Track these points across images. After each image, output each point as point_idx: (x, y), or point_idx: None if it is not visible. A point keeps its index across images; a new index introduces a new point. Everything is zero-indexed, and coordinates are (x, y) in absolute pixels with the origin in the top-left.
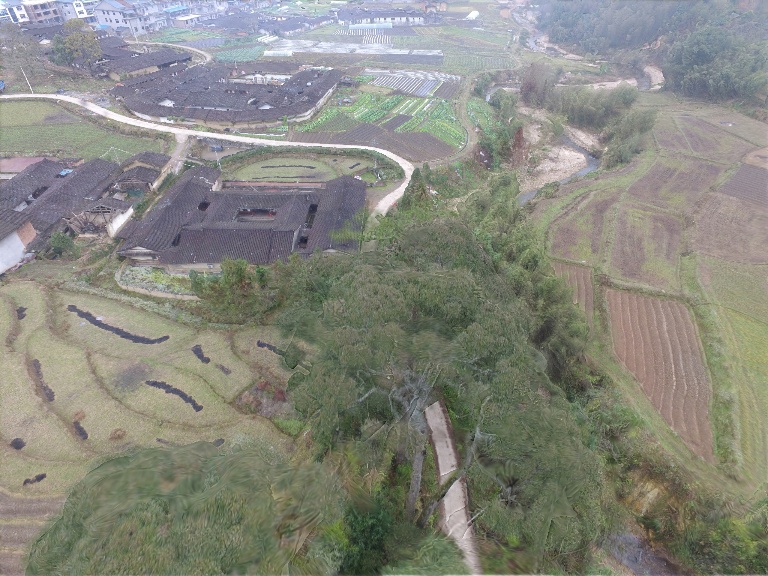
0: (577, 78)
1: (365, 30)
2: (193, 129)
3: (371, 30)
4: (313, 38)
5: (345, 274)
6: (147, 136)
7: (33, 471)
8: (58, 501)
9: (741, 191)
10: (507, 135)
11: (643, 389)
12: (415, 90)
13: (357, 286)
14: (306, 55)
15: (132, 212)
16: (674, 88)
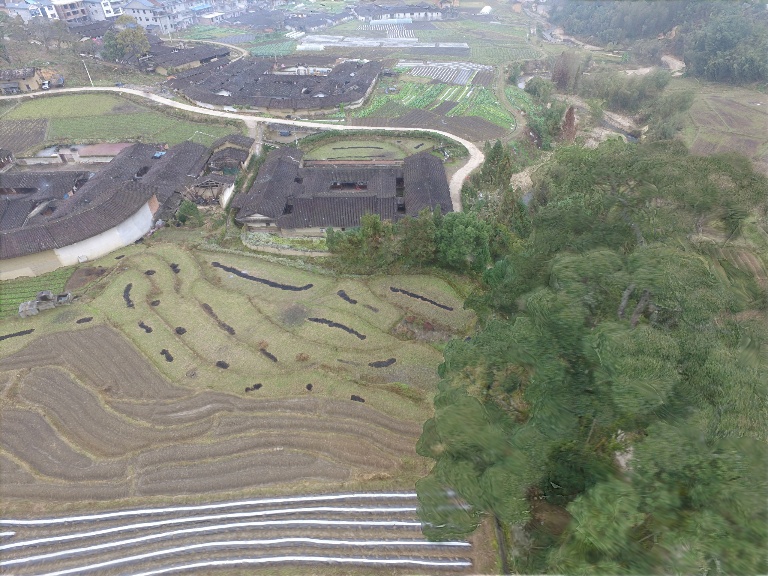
0: (601, 67)
1: (386, 25)
2: (259, 116)
3: (392, 25)
4: (338, 33)
5: (636, 163)
6: (217, 123)
7: (249, 382)
8: (284, 401)
9: None
10: (558, 116)
11: None
12: (453, 79)
13: (660, 165)
14: (337, 49)
15: (234, 187)
16: (696, 74)
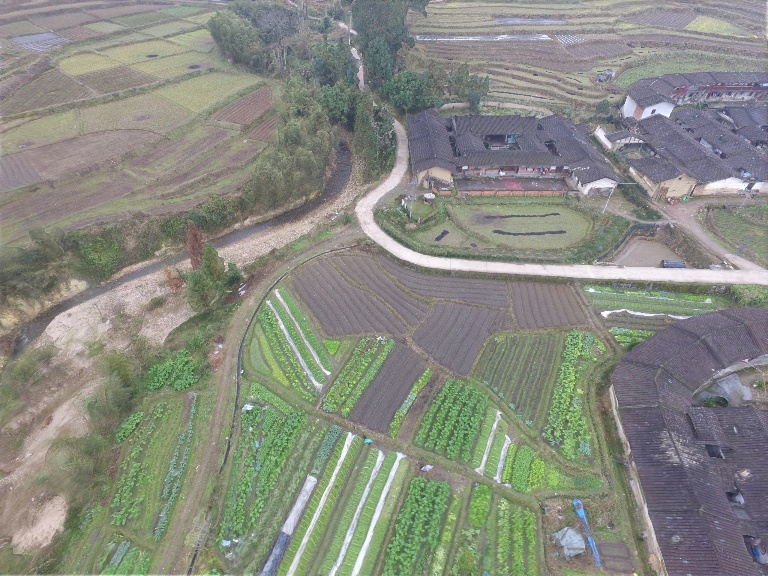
0: None
1: None
2: (760, 285)
3: None
4: None
5: None
6: None
7: None
8: None
9: (18, 181)
10: None
11: None
12: None
13: None
14: None
15: None
16: None
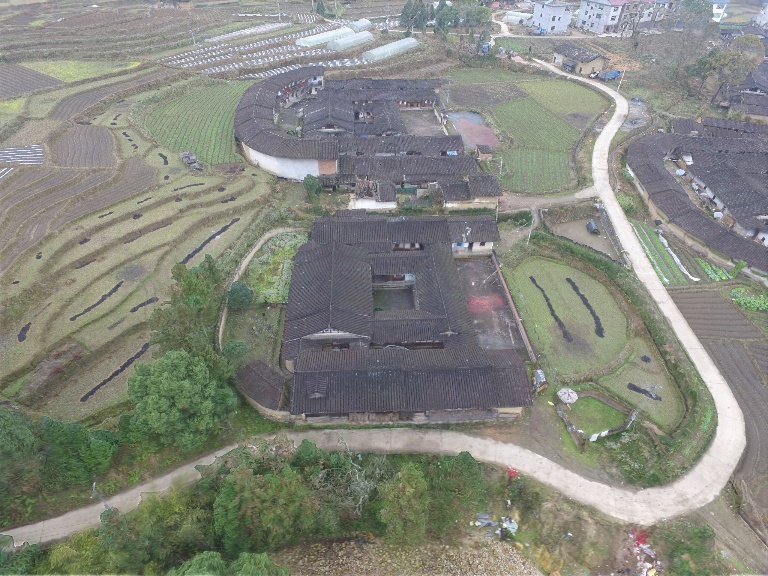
0: None
1: None
2: (617, 194)
3: None
4: None
5: None
6: (577, 172)
7: (47, 253)
8: None
9: None
10: None
11: None
12: None
13: None
14: None
15: (393, 207)
16: None
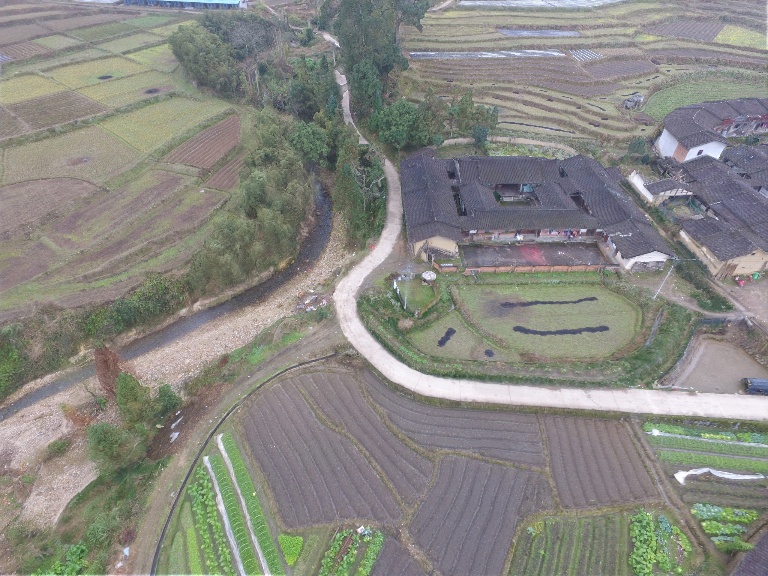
0: None
1: None
2: None
3: None
4: None
5: None
6: None
7: None
8: None
9: None
10: None
11: None
12: None
13: None
14: None
15: None
16: None
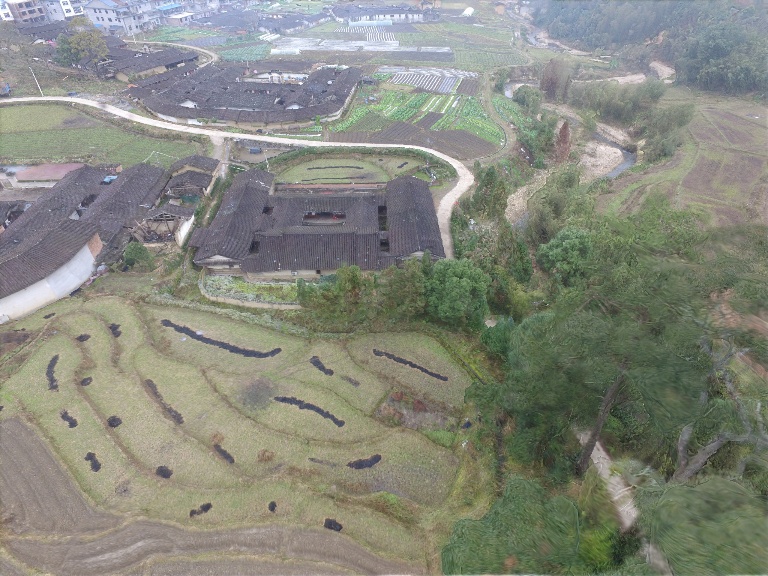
0: (589, 73)
1: (366, 27)
2: (227, 131)
3: (372, 27)
4: (315, 36)
5: (735, 284)
6: (180, 139)
7: (196, 501)
8: (238, 532)
9: None
10: (551, 131)
11: (765, 381)
12: (437, 87)
13: None
14: (314, 53)
15: (193, 219)
16: (687, 82)
